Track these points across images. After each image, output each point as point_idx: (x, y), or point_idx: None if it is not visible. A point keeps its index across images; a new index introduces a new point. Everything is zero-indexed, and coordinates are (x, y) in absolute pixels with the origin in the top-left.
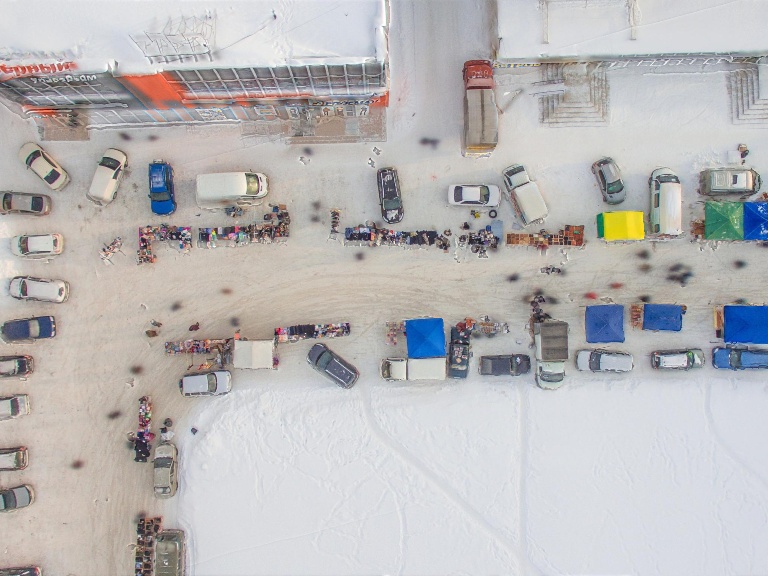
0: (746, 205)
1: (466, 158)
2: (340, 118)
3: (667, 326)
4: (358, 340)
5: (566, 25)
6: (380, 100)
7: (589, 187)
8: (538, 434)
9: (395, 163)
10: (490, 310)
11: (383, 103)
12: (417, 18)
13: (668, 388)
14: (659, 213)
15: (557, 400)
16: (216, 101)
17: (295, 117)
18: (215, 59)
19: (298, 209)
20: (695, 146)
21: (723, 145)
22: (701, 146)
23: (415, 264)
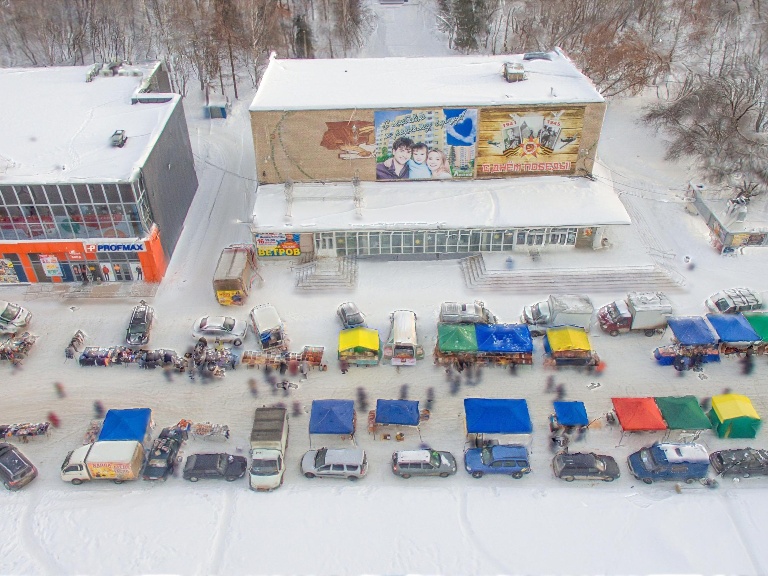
0: (477, 324)
1: (223, 308)
2: (119, 282)
3: (401, 417)
4: (55, 445)
5: (307, 209)
6: (146, 249)
7: (335, 327)
8: (239, 544)
9: (156, 309)
10: (214, 419)
11: (151, 256)
12: (208, 234)
13: (412, 493)
14: (393, 330)
15: (271, 504)
16: (5, 242)
17: (80, 281)
18: (1, 180)
19: (49, 339)
20: (435, 301)
21: (461, 301)
22: (441, 301)
23: (146, 379)
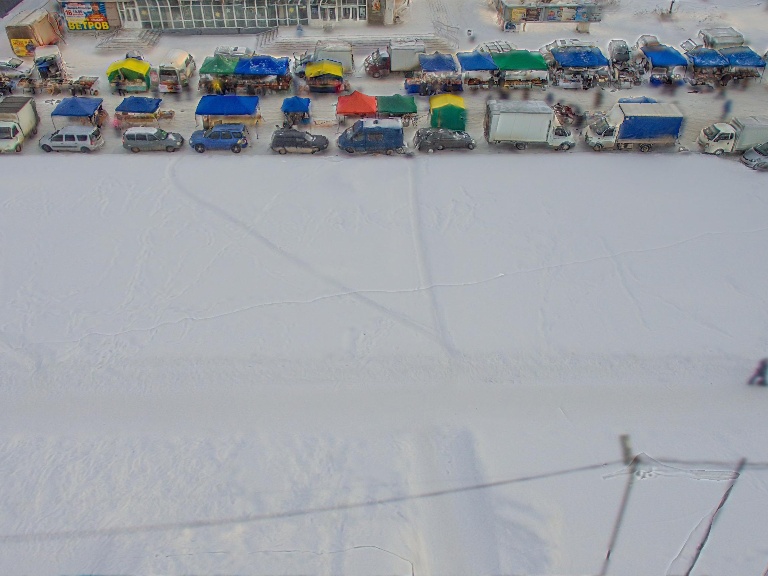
0: (241, 57)
1: None
2: None
3: (138, 105)
4: None
5: None
6: None
7: None
8: None
9: None
10: None
11: None
12: None
13: (133, 156)
14: None
15: None
16: None
17: None
18: None
19: None
20: None
21: None
22: None
23: None
